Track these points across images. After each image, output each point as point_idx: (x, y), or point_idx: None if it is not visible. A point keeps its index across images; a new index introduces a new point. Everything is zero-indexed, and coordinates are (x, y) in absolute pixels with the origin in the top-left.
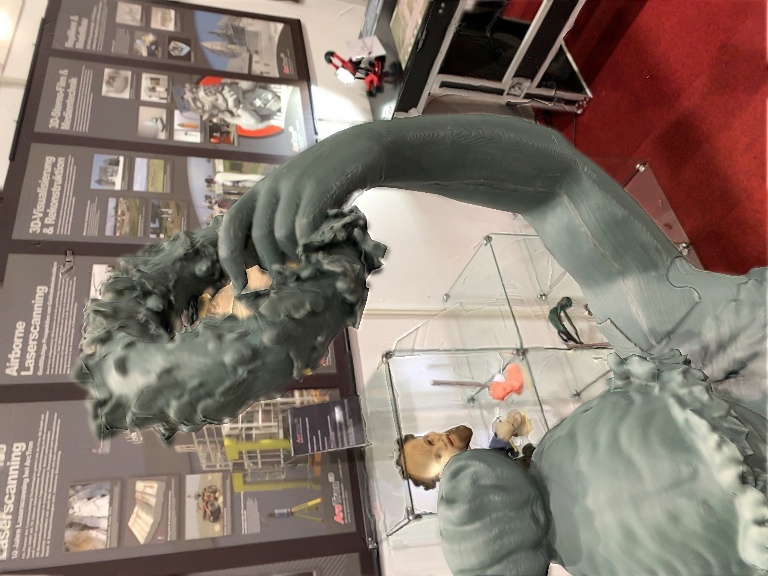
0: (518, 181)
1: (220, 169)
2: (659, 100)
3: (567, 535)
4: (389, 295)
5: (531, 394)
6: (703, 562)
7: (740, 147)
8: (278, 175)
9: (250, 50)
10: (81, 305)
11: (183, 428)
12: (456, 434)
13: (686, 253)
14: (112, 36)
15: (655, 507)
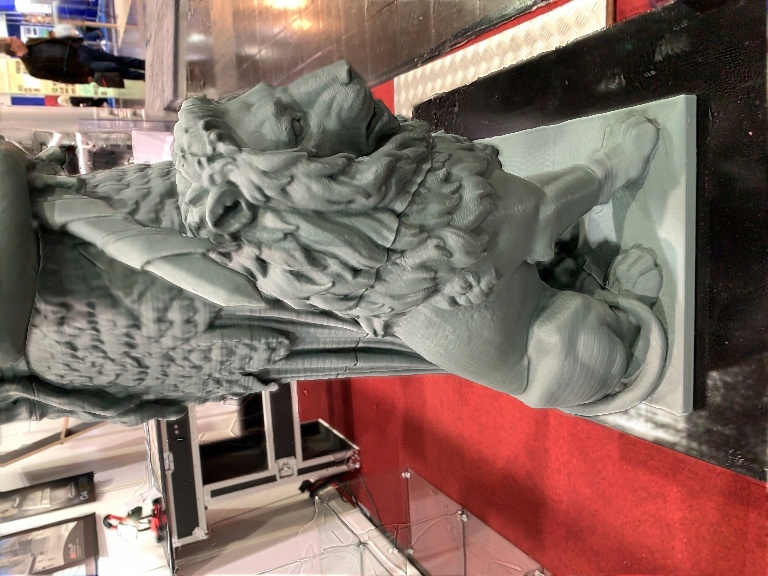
0: None
1: None
2: (388, 417)
3: None
4: None
5: None
6: None
7: (438, 409)
8: None
9: (34, 554)
10: None
11: None
12: None
13: (465, 519)
14: None
15: None
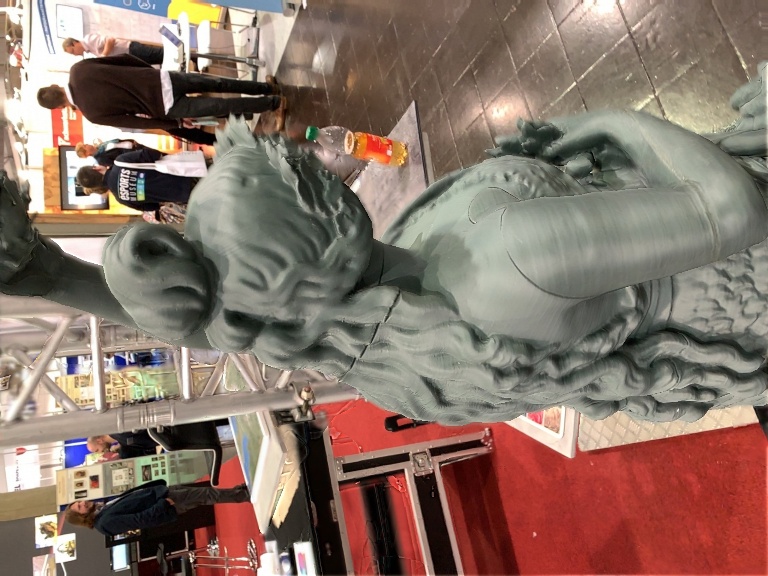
0: None
1: None
2: None
3: (189, 228)
4: None
5: None
6: (236, 157)
7: None
8: None
9: None
10: None
11: None
12: None
13: None
14: None
15: None
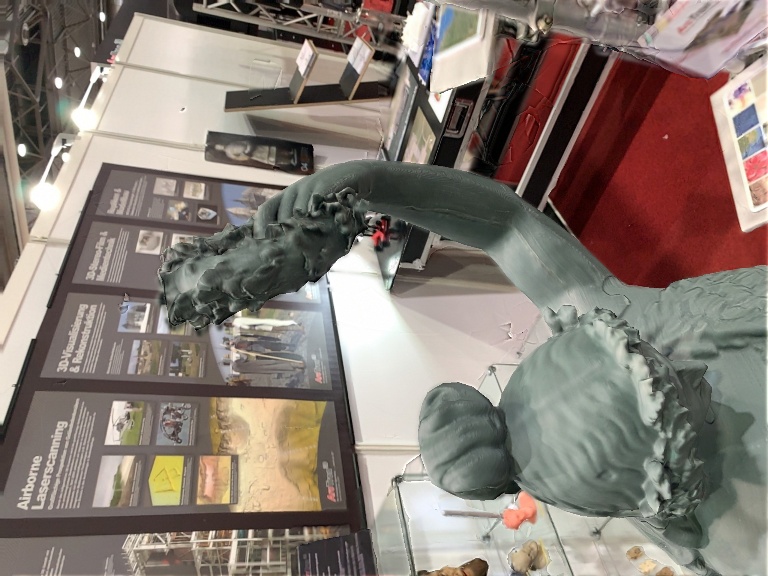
0: (476, 214)
1: (238, 314)
2: (642, 245)
3: (519, 439)
4: (399, 431)
5: (545, 521)
6: (616, 429)
7: None
8: (297, 182)
9: None
10: (98, 439)
11: (229, 307)
12: (471, 568)
13: None
14: (149, 204)
15: (576, 392)
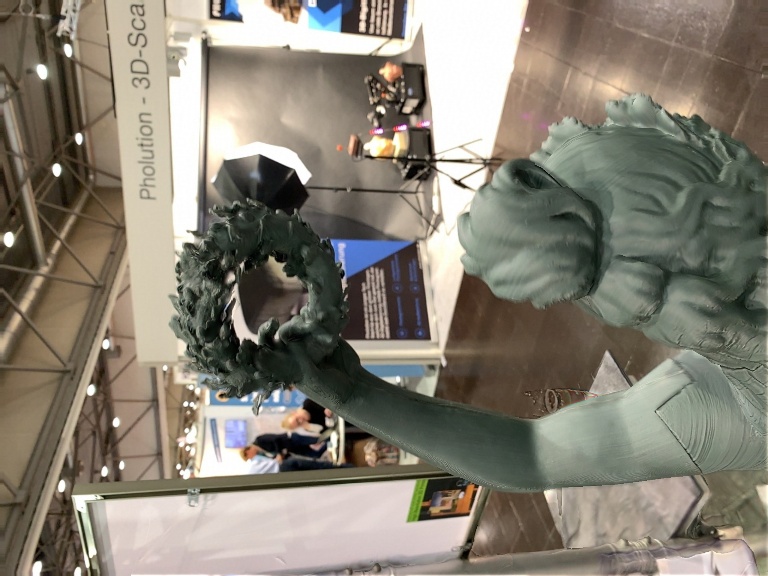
0: None
1: None
2: None
3: None
4: None
5: None
6: None
7: None
8: None
9: None
10: None
11: None
12: None
13: None
14: None
15: None
